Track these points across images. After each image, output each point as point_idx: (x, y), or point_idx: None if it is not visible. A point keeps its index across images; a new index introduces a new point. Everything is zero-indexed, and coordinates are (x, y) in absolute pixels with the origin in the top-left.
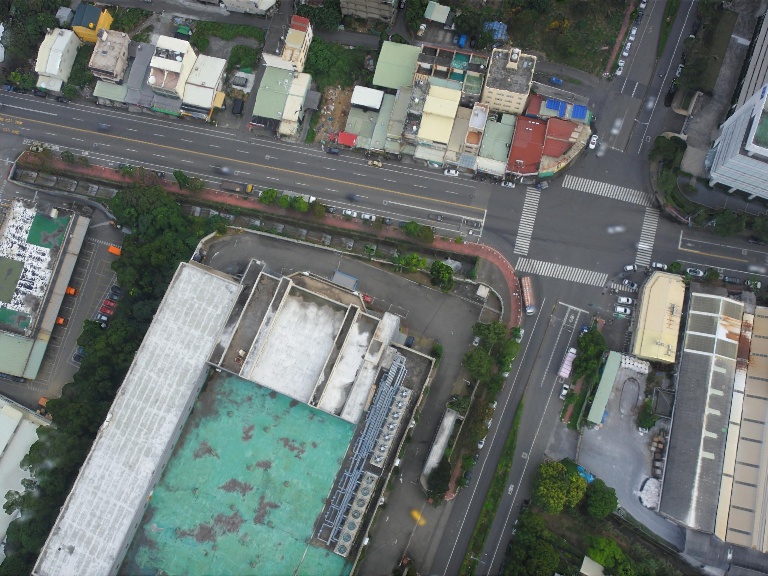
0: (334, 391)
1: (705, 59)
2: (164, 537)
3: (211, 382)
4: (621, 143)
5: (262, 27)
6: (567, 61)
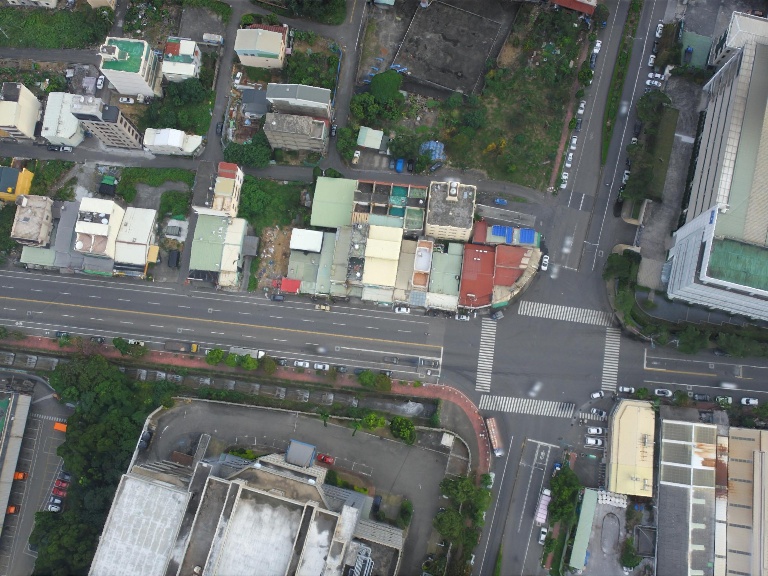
0: None
1: (650, 169)
2: None
3: None
4: (574, 261)
5: (190, 168)
6: (509, 177)
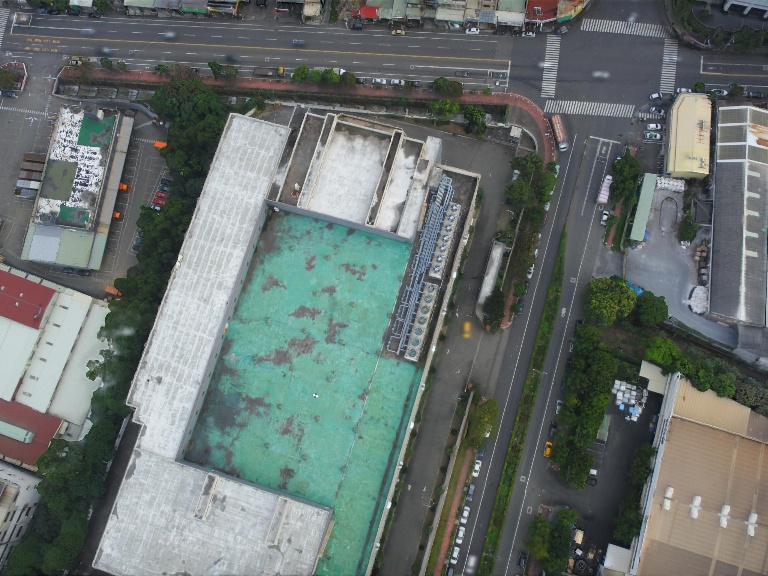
0: (388, 212)
1: None
2: (243, 364)
3: (270, 222)
4: None
5: None
6: None
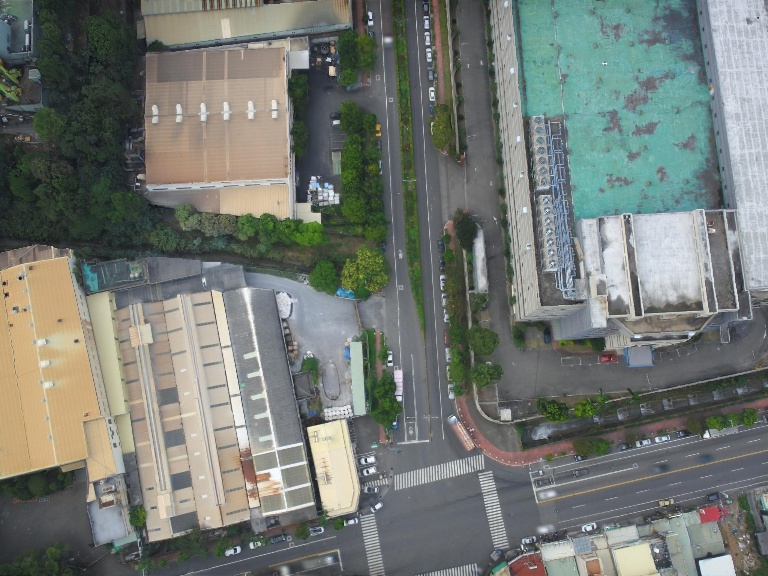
0: (614, 237)
1: None
2: (680, 67)
3: (718, 200)
4: None
5: None
6: None
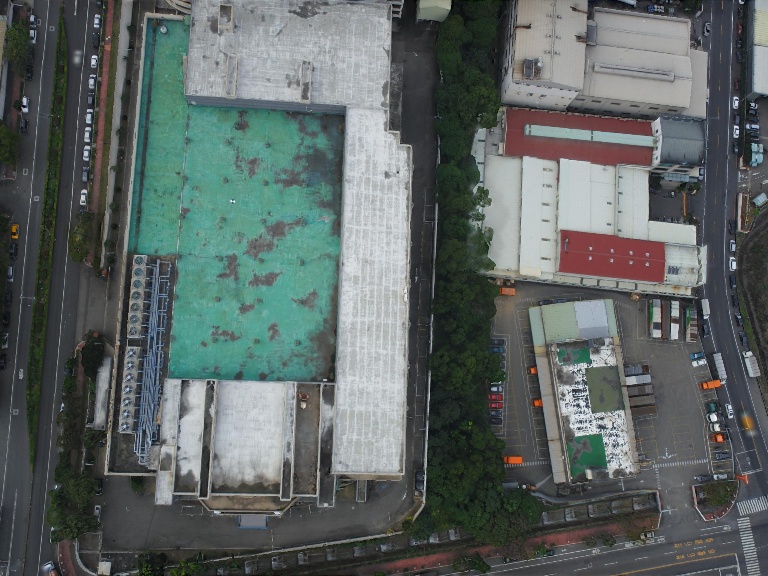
0: (197, 403)
1: None
2: (314, 214)
3: (329, 366)
4: None
5: None
6: None
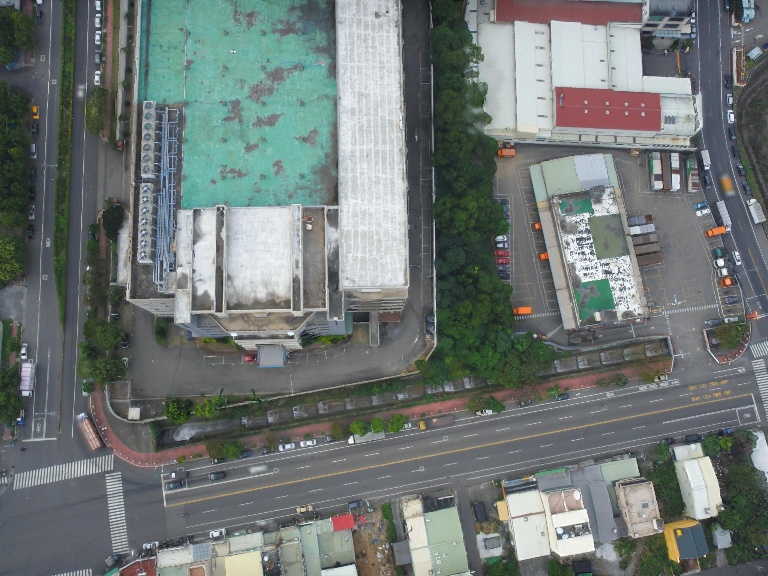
0: (209, 229)
1: None
2: (311, 59)
3: (332, 196)
4: None
5: None
6: None
